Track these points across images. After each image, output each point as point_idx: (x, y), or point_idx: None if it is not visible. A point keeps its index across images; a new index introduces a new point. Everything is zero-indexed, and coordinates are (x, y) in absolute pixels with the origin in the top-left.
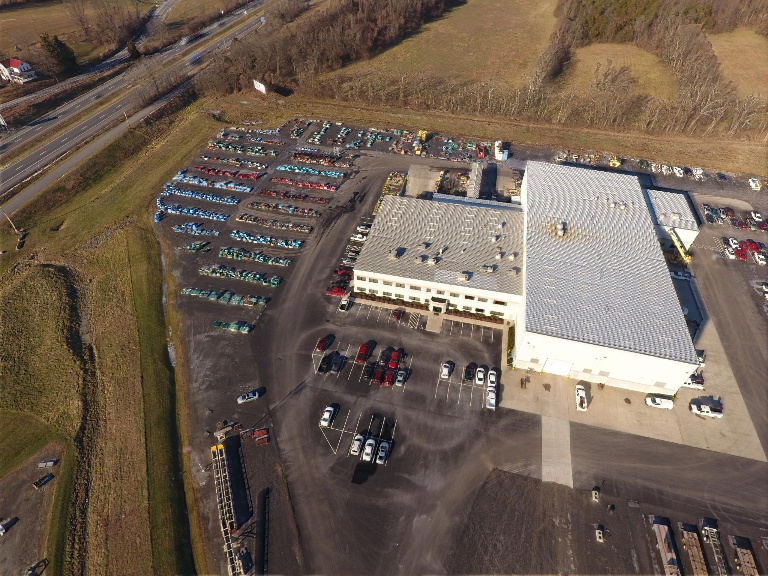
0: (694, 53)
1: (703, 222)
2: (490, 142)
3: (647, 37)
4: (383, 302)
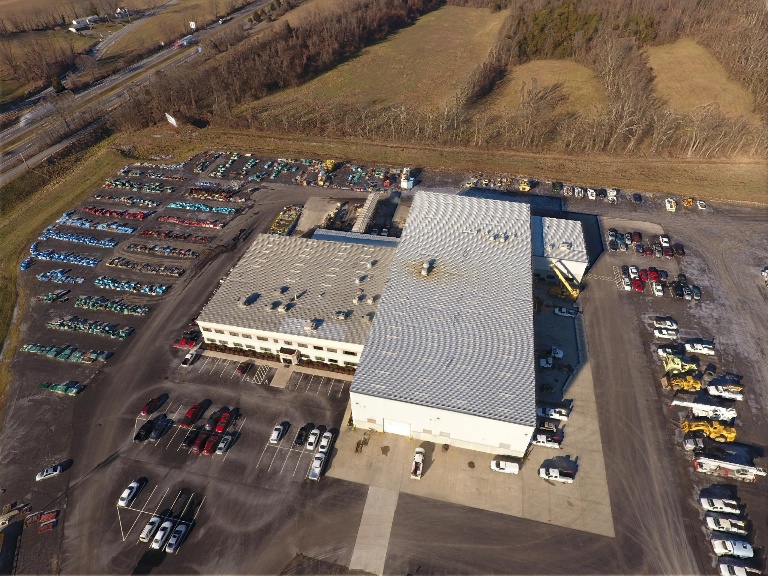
0: (625, 67)
1: (605, 249)
2: (400, 169)
3: (585, 52)
4: (233, 354)
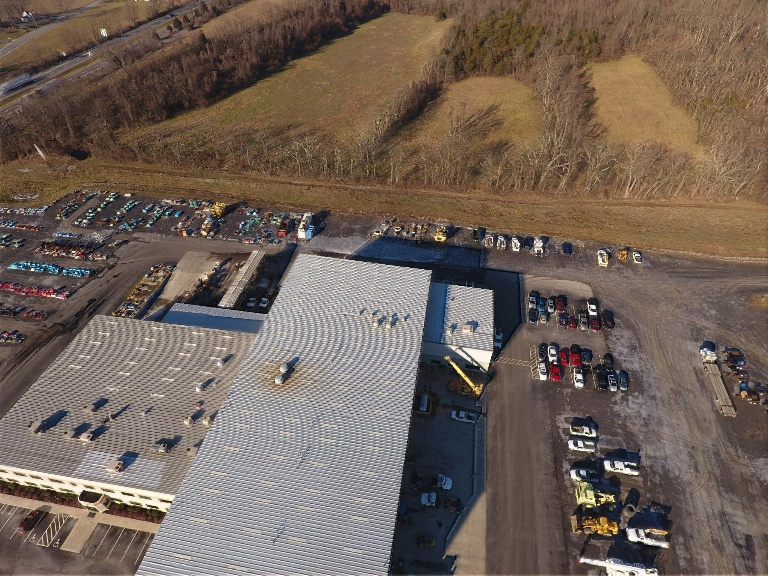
0: (563, 89)
1: (524, 321)
2: (302, 213)
3: (525, 69)
4: (24, 497)
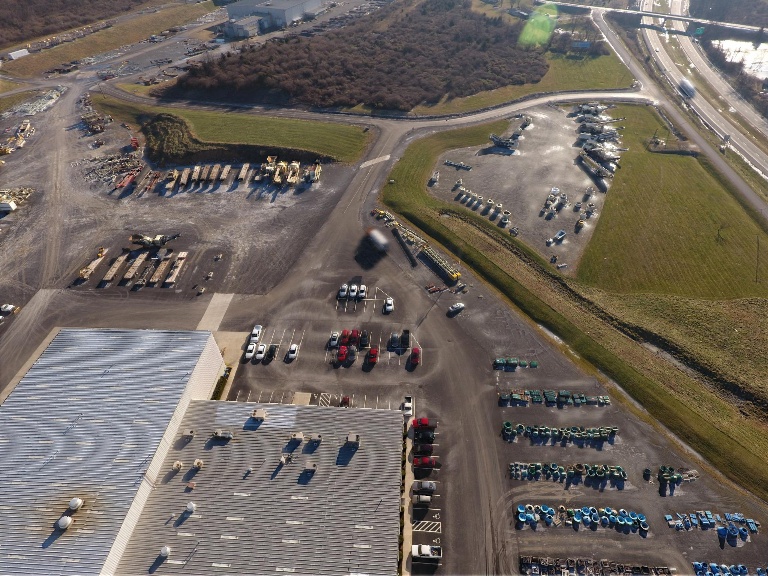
0: None
1: None
2: None
3: None
4: None
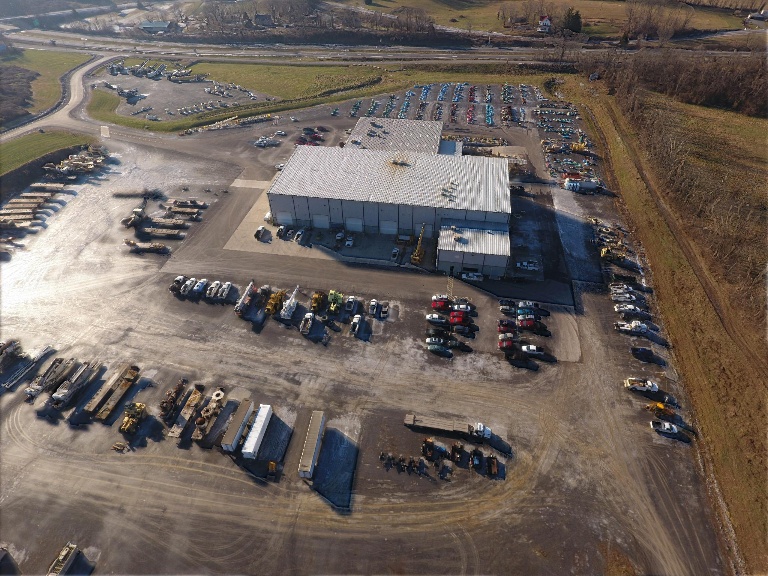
0: None
1: (501, 298)
2: None
3: None
4: None
